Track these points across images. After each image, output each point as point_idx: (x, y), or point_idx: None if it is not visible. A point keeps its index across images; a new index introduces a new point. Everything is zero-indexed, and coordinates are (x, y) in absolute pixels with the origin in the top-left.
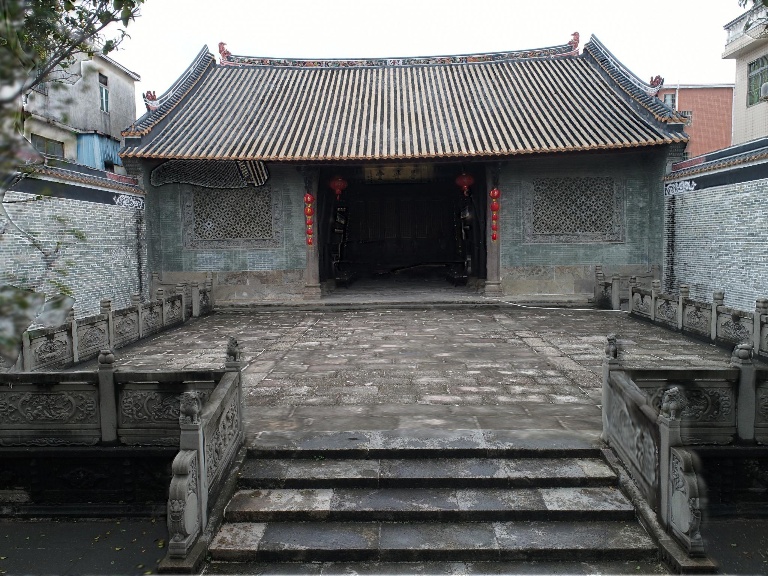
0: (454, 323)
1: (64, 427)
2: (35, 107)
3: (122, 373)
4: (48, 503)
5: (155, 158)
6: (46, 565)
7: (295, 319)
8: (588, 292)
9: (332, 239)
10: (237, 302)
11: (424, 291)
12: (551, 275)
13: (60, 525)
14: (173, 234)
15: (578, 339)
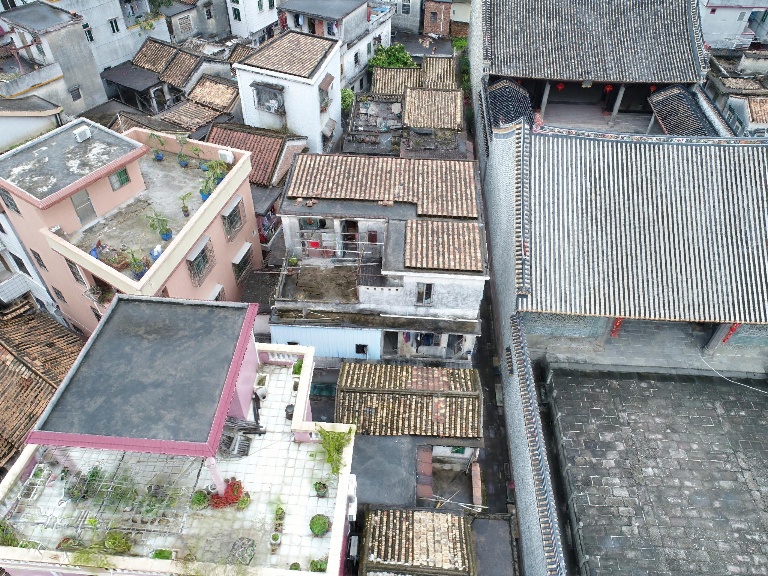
0: (702, 429)
1: None
2: None
3: None
4: None
5: (540, 312)
6: None
7: (610, 401)
8: (765, 356)
9: None
10: (555, 351)
11: None
12: (747, 348)
13: None
14: None
15: None
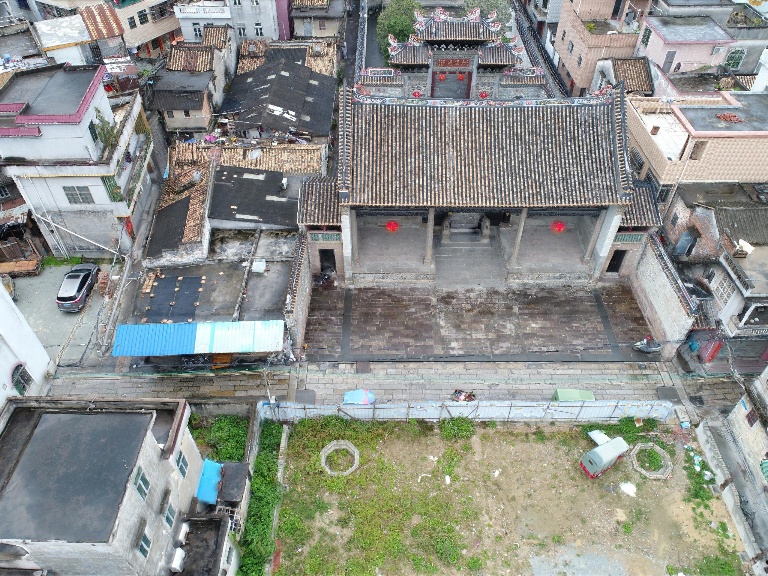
0: None
1: None
2: None
3: None
4: None
5: None
6: None
7: None
8: None
9: None
10: (388, 2)
11: None
12: None
13: None
14: None
15: None
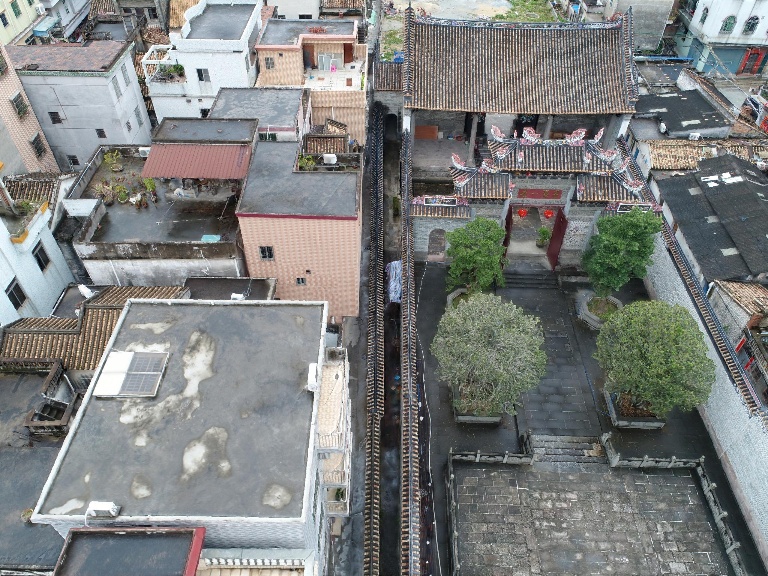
0: None
1: None
2: None
3: None
4: None
5: None
6: (631, 455)
7: None
8: None
9: None
10: None
11: None
12: None
13: None
14: None
15: None
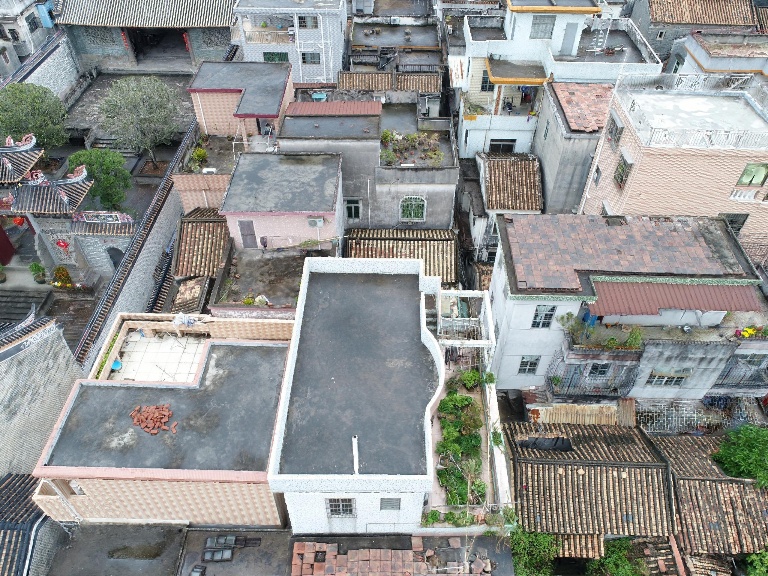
0: None
1: (71, 135)
2: (22, 8)
3: (77, 128)
4: (73, 144)
5: (67, 24)
6: None
7: None
8: None
9: (141, 35)
10: (109, 66)
11: (180, 56)
12: None
13: (75, 147)
14: (81, 41)
15: (181, 103)
